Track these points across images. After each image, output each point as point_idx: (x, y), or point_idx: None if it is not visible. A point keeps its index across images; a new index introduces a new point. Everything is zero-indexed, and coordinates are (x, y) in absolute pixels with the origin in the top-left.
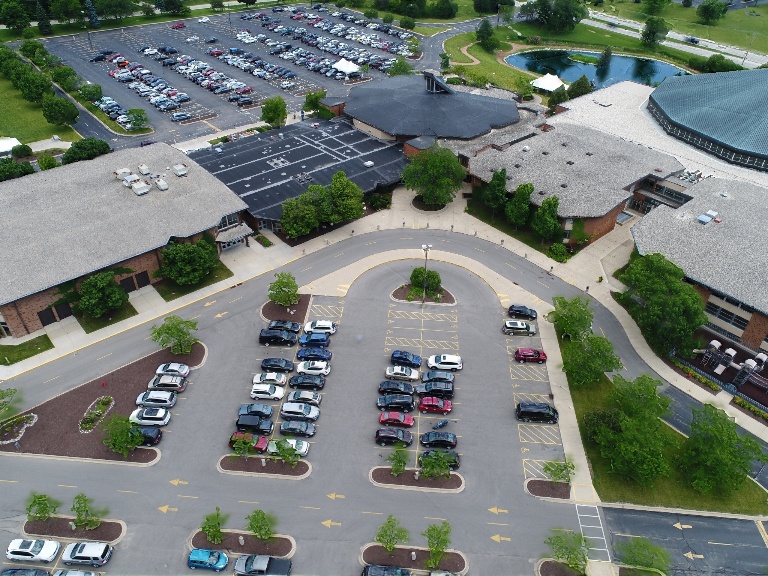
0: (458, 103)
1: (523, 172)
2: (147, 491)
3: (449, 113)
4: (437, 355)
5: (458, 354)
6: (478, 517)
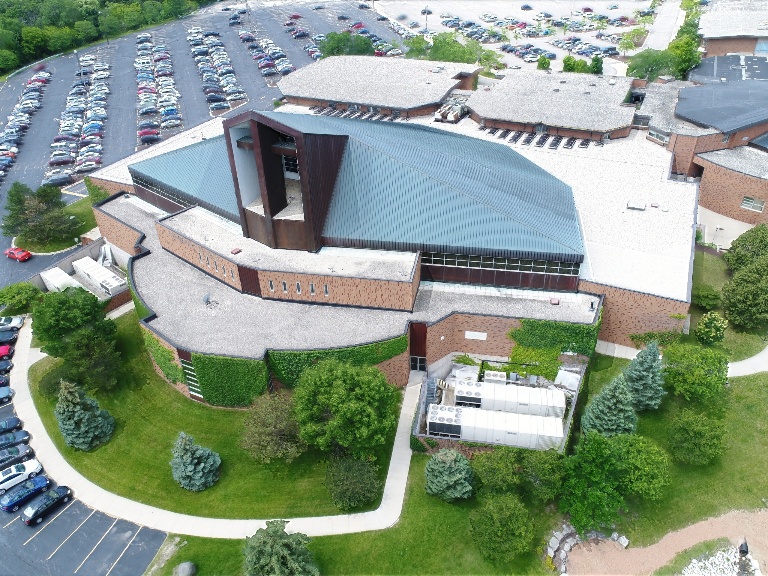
0: (758, 98)
1: (591, 76)
2: (582, 35)
3: (741, 90)
4: (538, 57)
5: (531, 64)
6: (485, 47)
